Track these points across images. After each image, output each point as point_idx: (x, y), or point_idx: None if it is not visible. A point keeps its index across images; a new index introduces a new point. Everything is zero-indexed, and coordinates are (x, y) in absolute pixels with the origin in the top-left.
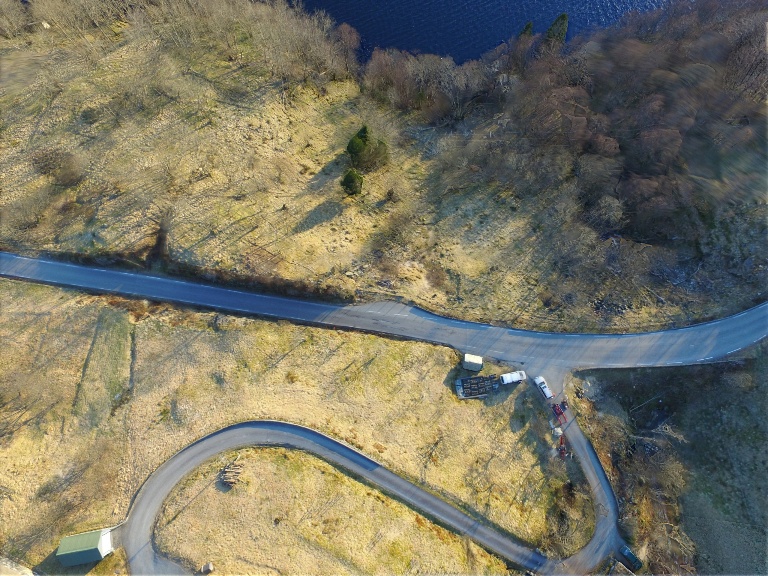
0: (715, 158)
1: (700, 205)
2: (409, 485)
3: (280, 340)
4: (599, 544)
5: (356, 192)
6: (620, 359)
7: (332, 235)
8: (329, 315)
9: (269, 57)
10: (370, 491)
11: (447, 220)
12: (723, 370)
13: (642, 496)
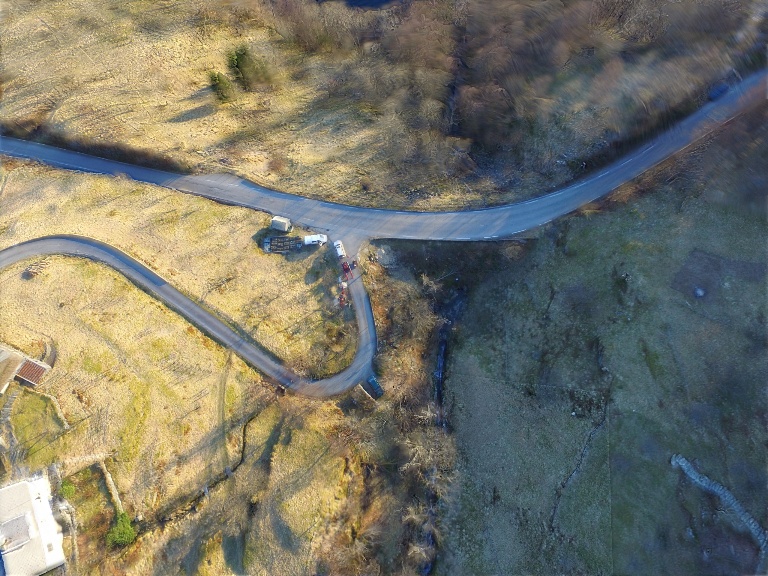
0: (558, 82)
1: (522, 114)
2: (189, 301)
3: (117, 187)
4: (352, 374)
5: (229, 95)
6: (415, 232)
7: (201, 127)
8: (174, 181)
9: (202, 1)
10: (155, 302)
11: (311, 127)
12: (506, 247)
13: (408, 345)
